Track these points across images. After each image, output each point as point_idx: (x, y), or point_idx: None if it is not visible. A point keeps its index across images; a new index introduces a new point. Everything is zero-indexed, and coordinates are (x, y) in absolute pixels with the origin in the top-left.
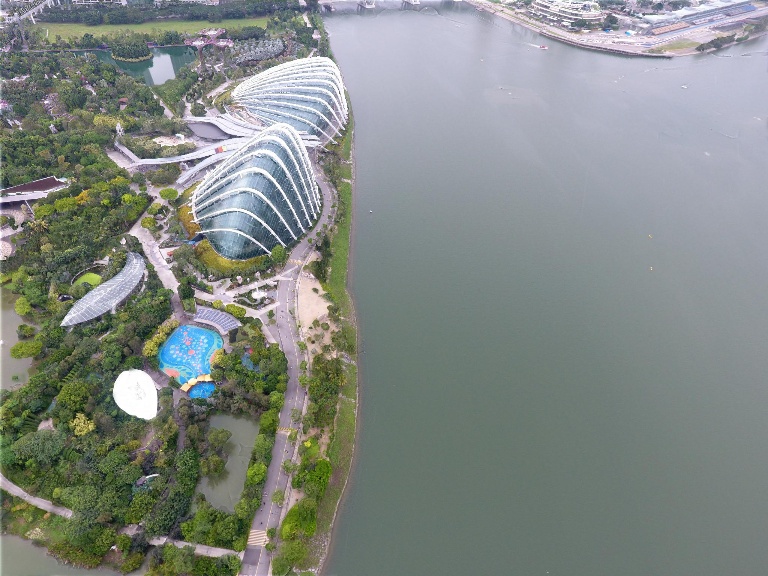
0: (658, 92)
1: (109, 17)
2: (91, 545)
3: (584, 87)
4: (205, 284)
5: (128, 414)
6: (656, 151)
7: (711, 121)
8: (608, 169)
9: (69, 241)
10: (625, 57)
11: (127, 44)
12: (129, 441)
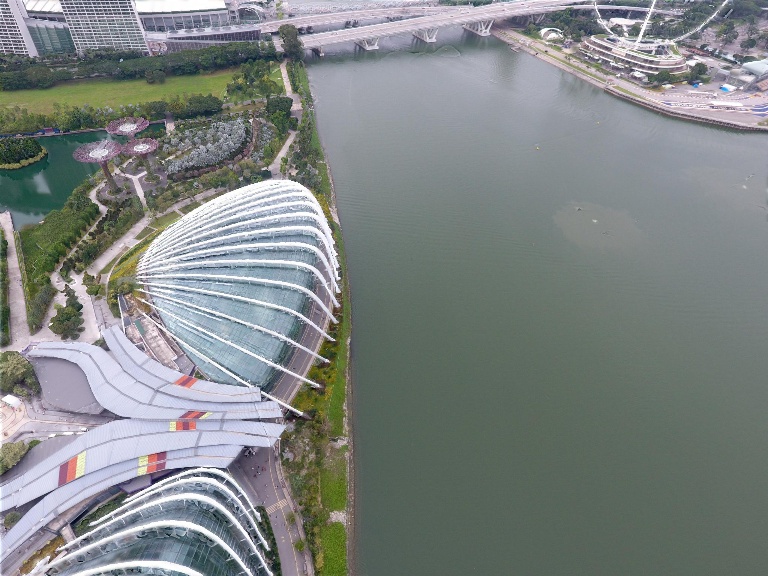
0: None
1: (0, 81)
2: None
3: (701, 200)
4: None
5: None
6: None
7: None
8: None
9: None
10: (734, 132)
11: (3, 139)
12: None
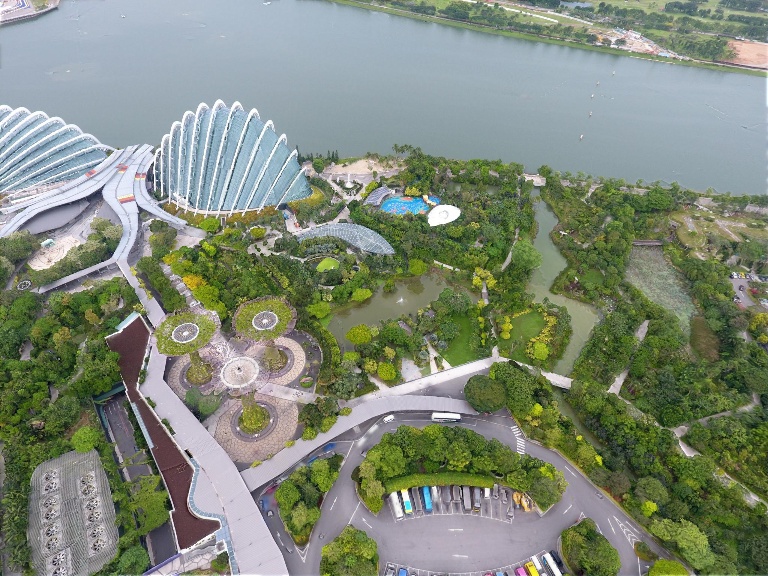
0: (119, 26)
1: None
2: (531, 216)
3: (82, 45)
4: None
5: None
6: None
7: (177, 25)
8: (227, 64)
9: (267, 288)
10: (32, 20)
11: None
12: (478, 211)
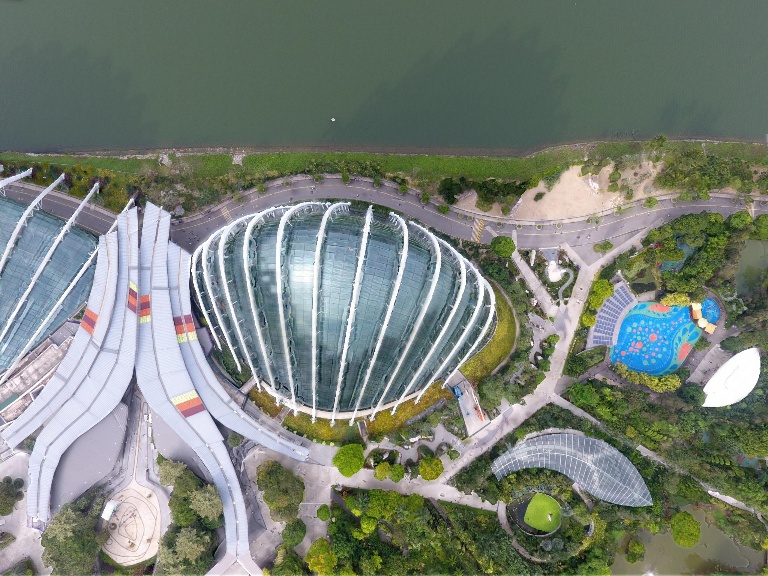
0: None
1: None
2: None
3: None
4: (548, 347)
5: (759, 377)
6: None
7: None
8: None
9: None
10: None
11: None
12: None
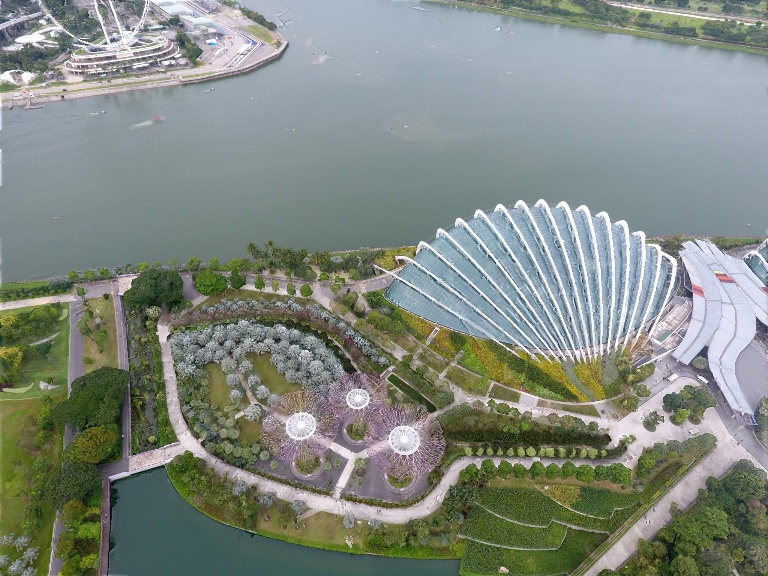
0: (382, 64)
1: None
2: None
3: (373, 90)
4: None
5: None
6: (515, 87)
7: (440, 60)
8: (563, 109)
9: None
10: (278, 60)
11: None
12: None
